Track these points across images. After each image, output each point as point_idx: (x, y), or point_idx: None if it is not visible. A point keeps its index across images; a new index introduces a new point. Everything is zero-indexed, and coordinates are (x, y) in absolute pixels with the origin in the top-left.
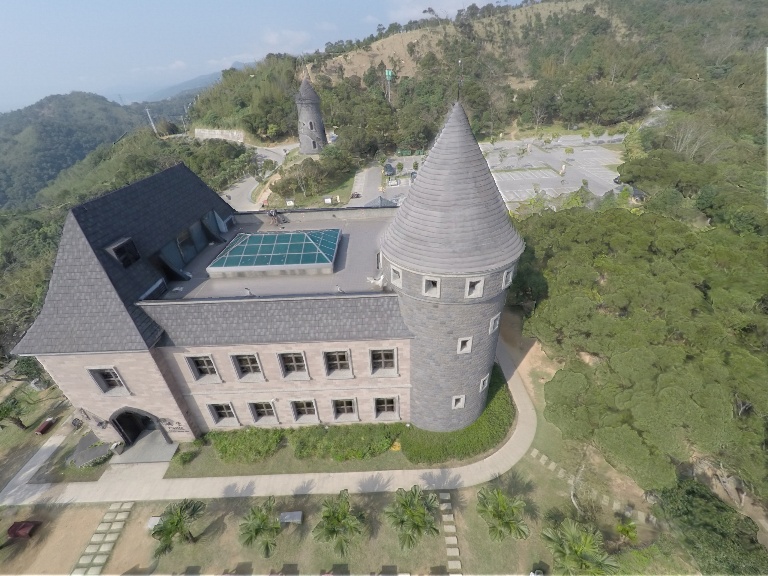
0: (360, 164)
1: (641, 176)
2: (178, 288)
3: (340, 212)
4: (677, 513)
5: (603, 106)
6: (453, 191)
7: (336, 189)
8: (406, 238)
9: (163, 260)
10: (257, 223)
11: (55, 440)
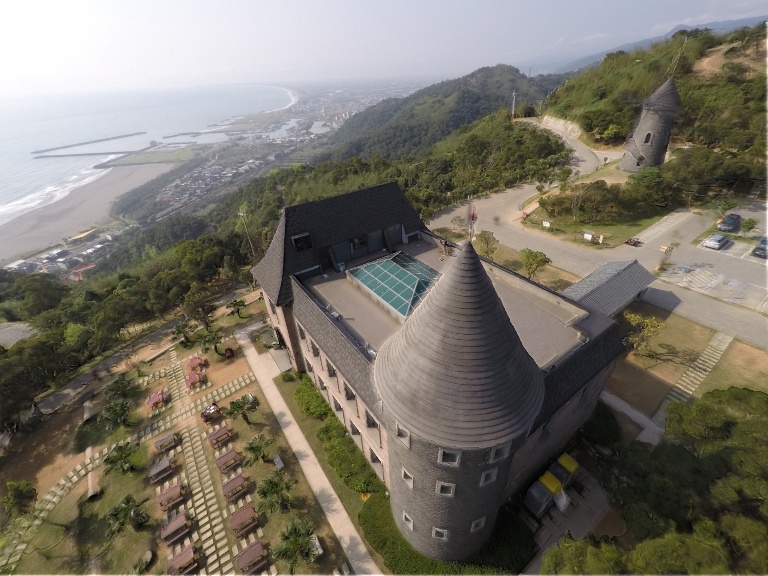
0: (696, 200)
1: None
2: (326, 275)
3: (496, 269)
4: None
5: None
6: (422, 330)
7: (621, 224)
8: None
9: (330, 253)
10: (434, 245)
11: None
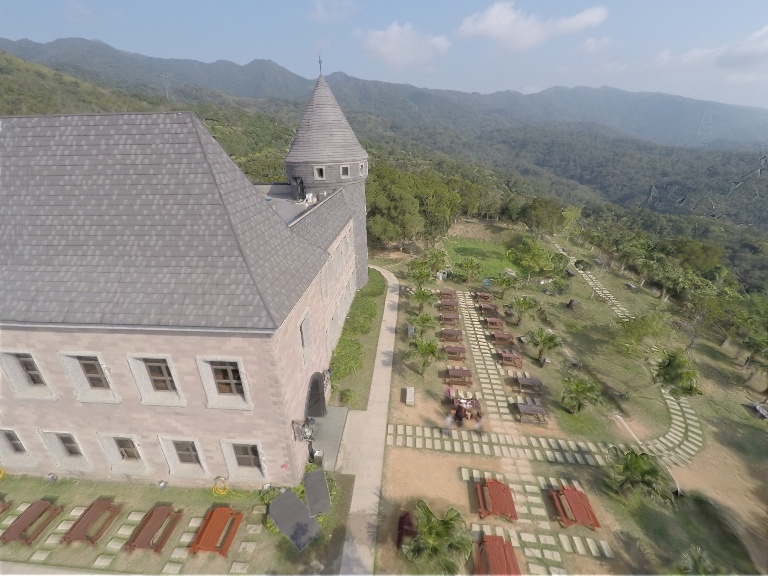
0: None
1: None
2: None
3: None
4: (430, 227)
5: None
6: None
7: None
8: (341, 146)
9: None
10: None
11: None
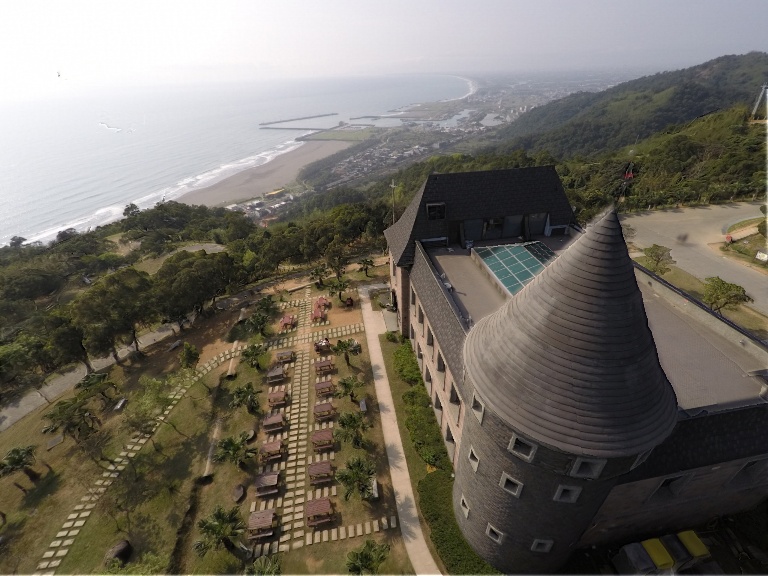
0: None
1: None
2: (451, 249)
3: (658, 284)
4: None
5: None
6: (528, 303)
7: None
8: None
9: (460, 227)
10: None
11: None
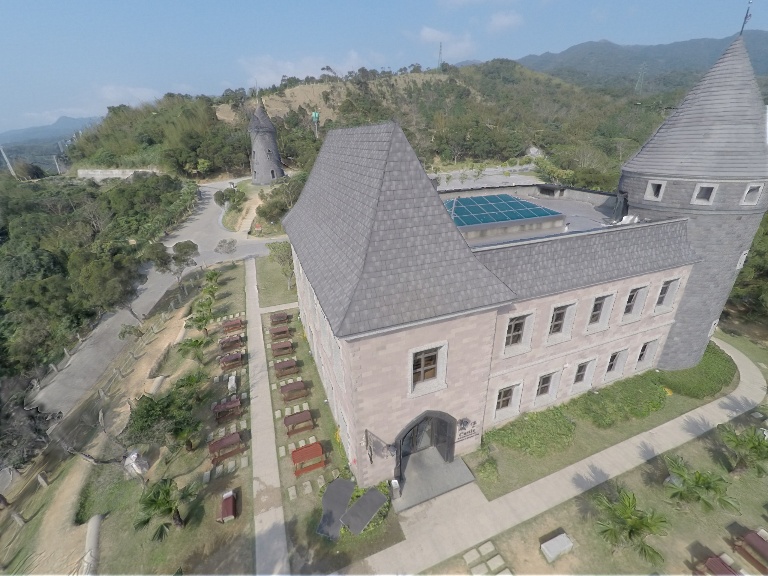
0: None
1: (592, 182)
2: None
3: (466, 193)
4: None
5: (503, 145)
6: (757, 106)
7: None
8: (718, 153)
9: None
10: None
11: (269, 517)
